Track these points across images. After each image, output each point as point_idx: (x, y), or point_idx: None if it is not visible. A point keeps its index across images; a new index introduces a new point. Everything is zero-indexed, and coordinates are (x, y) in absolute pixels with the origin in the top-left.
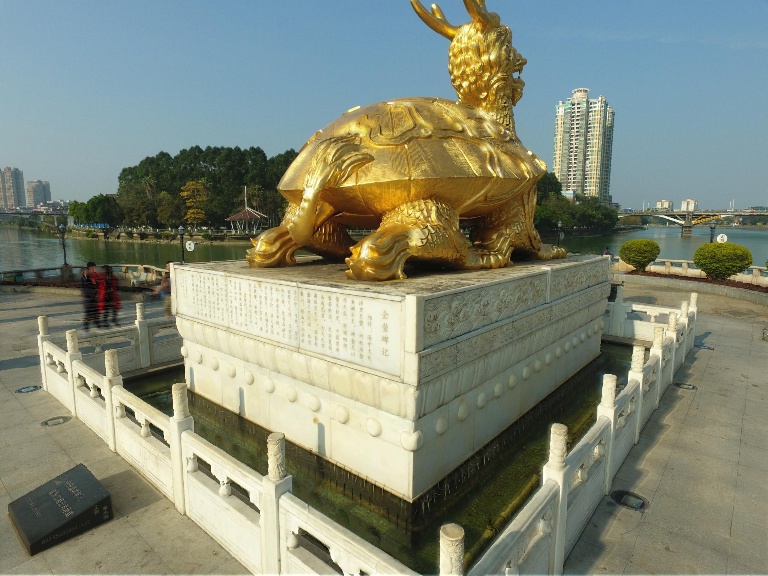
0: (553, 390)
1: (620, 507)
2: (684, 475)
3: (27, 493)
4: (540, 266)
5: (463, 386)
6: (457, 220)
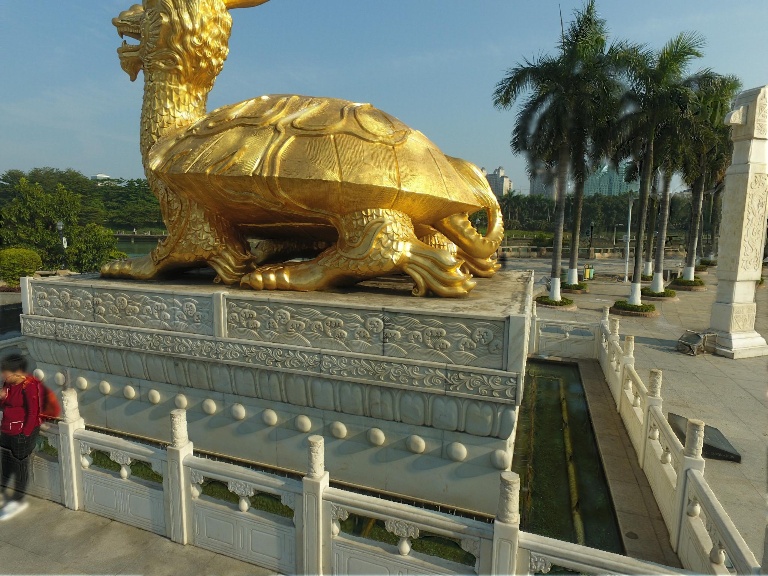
0: None
1: None
2: None
3: (728, 452)
4: None
5: None
6: None
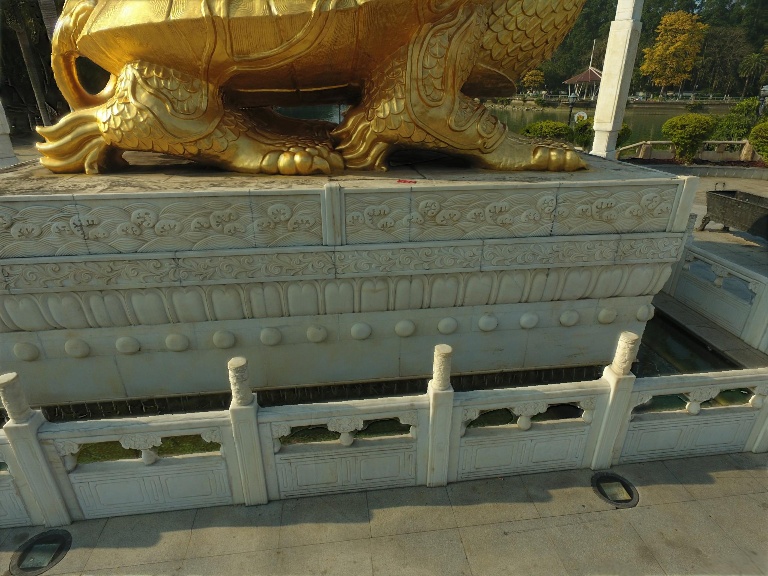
0: (391, 379)
1: (14, 548)
2: None
3: None
4: (375, 181)
5: (58, 319)
6: (202, 95)
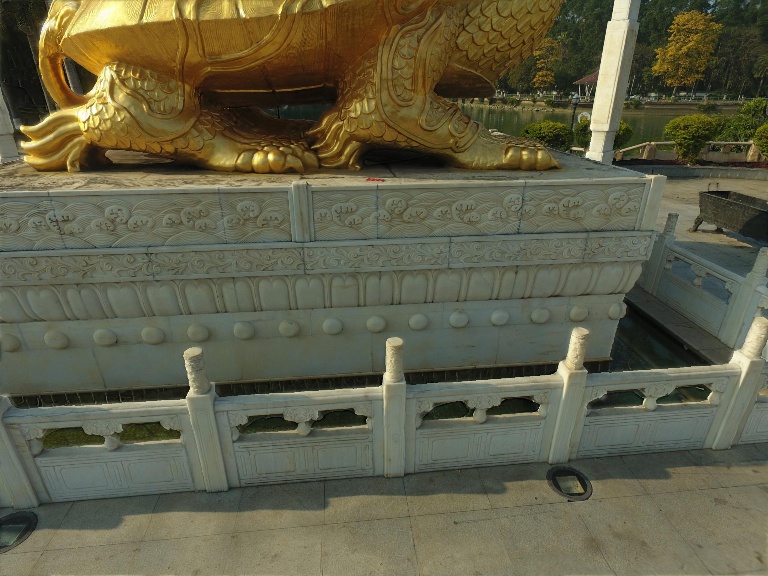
0: (364, 374)
1: None
2: (116, 568)
3: None
4: (345, 179)
5: (37, 311)
6: (178, 95)
